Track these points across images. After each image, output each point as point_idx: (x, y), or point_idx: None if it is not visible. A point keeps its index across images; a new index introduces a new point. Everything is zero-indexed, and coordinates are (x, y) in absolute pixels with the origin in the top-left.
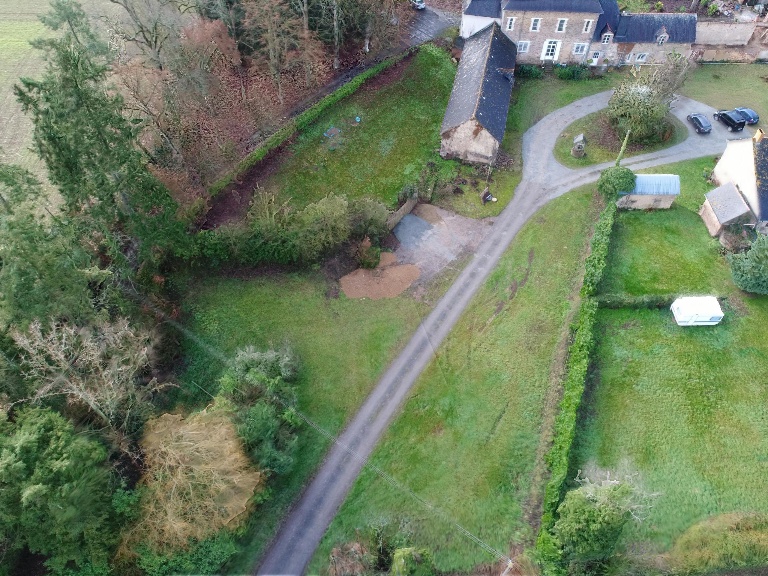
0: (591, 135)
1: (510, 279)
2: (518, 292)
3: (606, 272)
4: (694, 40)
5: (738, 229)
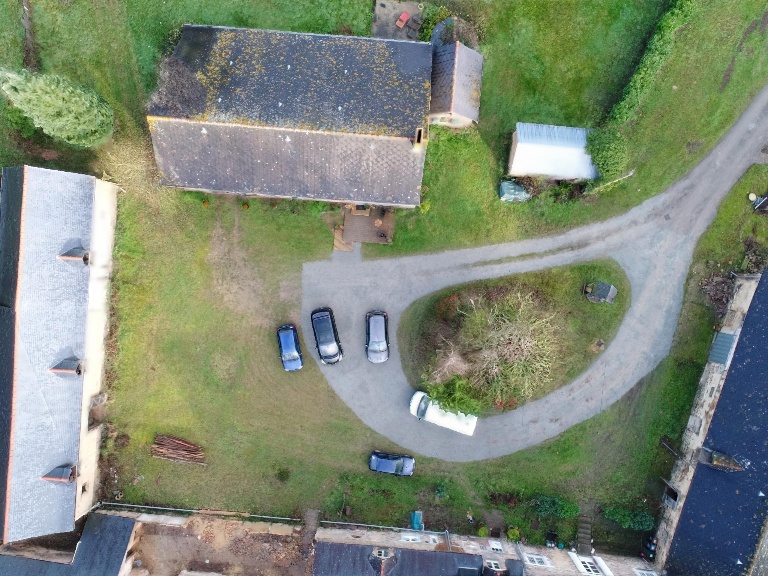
0: (558, 338)
1: (767, 35)
2: (764, 10)
3: (653, 13)
4: (319, 547)
5: (465, 39)
